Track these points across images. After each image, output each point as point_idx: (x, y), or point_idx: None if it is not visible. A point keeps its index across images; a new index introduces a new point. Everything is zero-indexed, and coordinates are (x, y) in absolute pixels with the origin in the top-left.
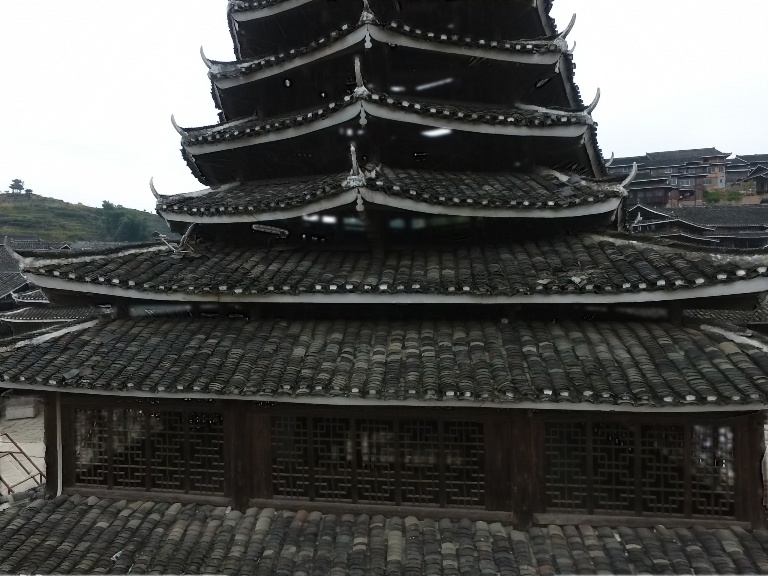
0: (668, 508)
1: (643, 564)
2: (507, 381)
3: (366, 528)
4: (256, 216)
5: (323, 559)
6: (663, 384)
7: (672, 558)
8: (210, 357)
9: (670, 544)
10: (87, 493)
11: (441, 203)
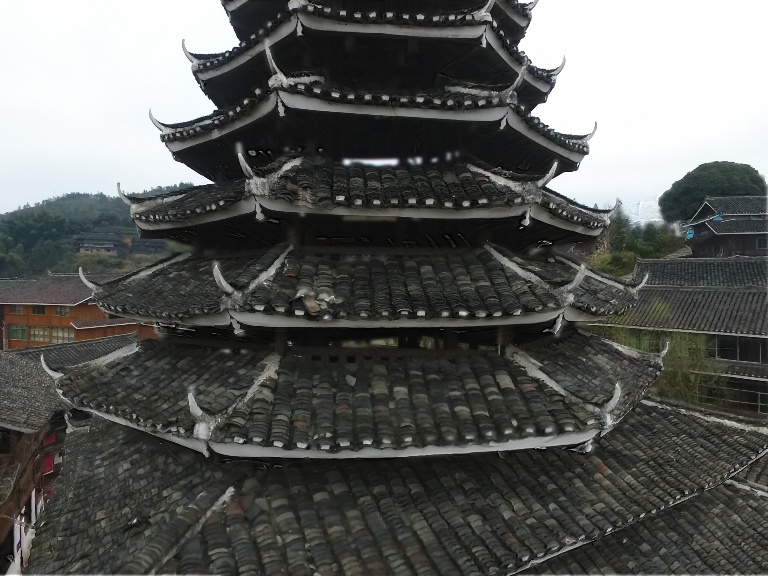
0: None
1: None
2: None
3: None
4: None
5: None
6: None
7: None
8: None
9: None
10: None
11: None
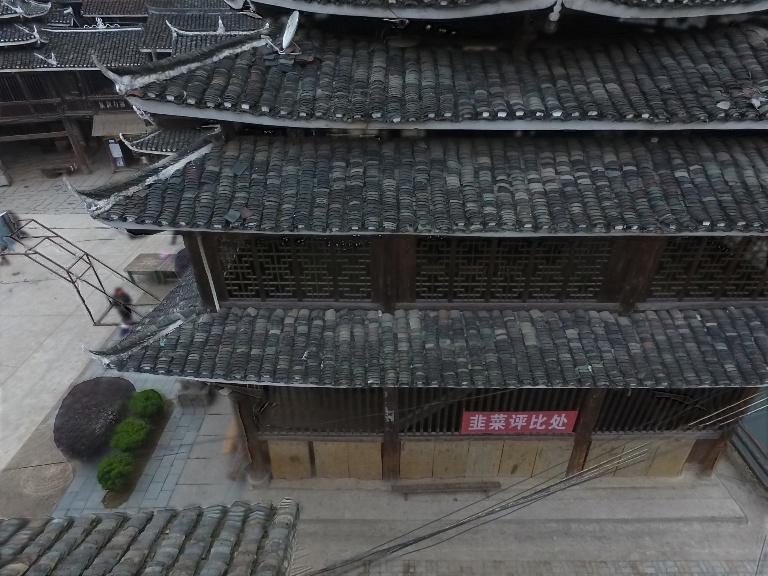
0: (741, 294)
1: (720, 337)
2: (669, 213)
3: (502, 322)
4: (396, 11)
5: (477, 348)
6: None
7: (740, 331)
8: (363, 189)
9: (739, 321)
10: (243, 305)
11: (640, 4)
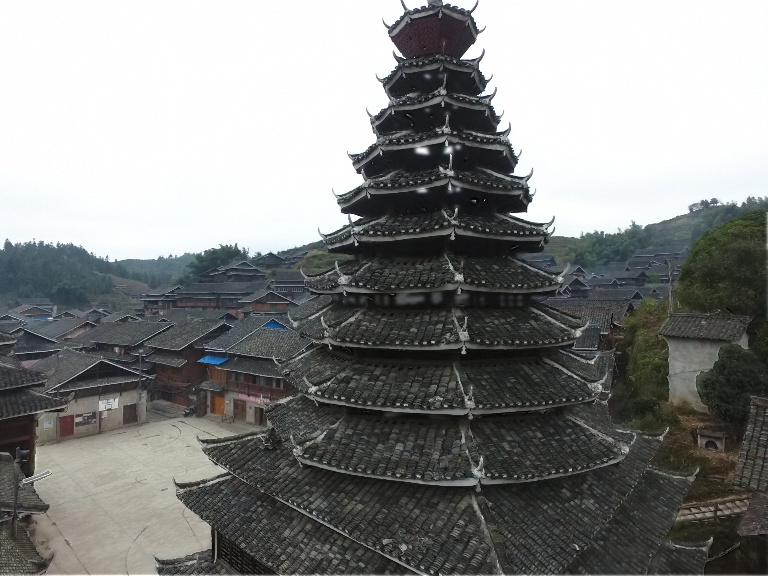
0: None
1: None
2: None
3: None
4: None
5: None
6: None
7: None
8: None
9: None
10: (223, 566)
11: None
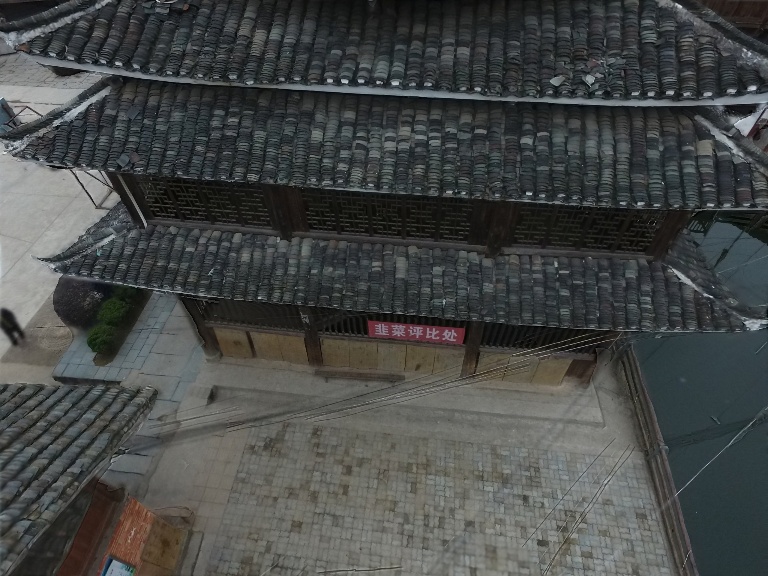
0: (600, 247)
1: (565, 285)
2: (498, 181)
3: (380, 255)
4: None
5: (352, 277)
6: (626, 188)
7: (587, 280)
8: (237, 139)
9: (590, 271)
10: (167, 224)
11: None
